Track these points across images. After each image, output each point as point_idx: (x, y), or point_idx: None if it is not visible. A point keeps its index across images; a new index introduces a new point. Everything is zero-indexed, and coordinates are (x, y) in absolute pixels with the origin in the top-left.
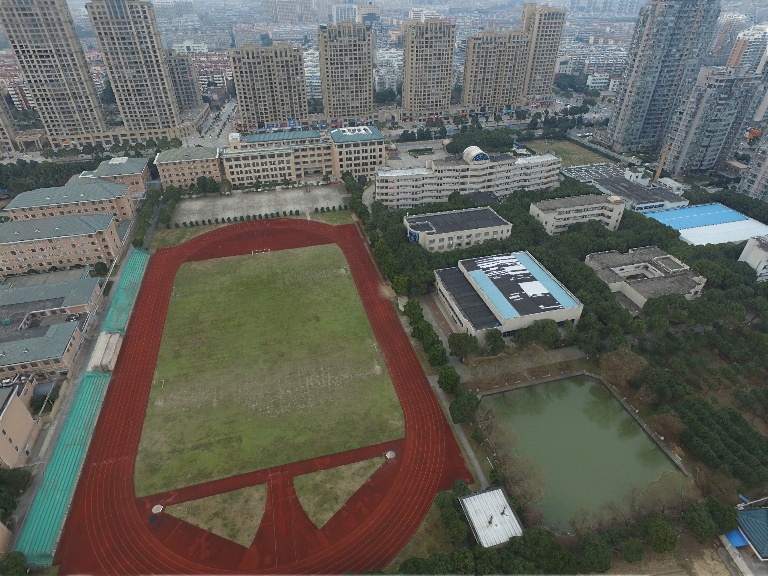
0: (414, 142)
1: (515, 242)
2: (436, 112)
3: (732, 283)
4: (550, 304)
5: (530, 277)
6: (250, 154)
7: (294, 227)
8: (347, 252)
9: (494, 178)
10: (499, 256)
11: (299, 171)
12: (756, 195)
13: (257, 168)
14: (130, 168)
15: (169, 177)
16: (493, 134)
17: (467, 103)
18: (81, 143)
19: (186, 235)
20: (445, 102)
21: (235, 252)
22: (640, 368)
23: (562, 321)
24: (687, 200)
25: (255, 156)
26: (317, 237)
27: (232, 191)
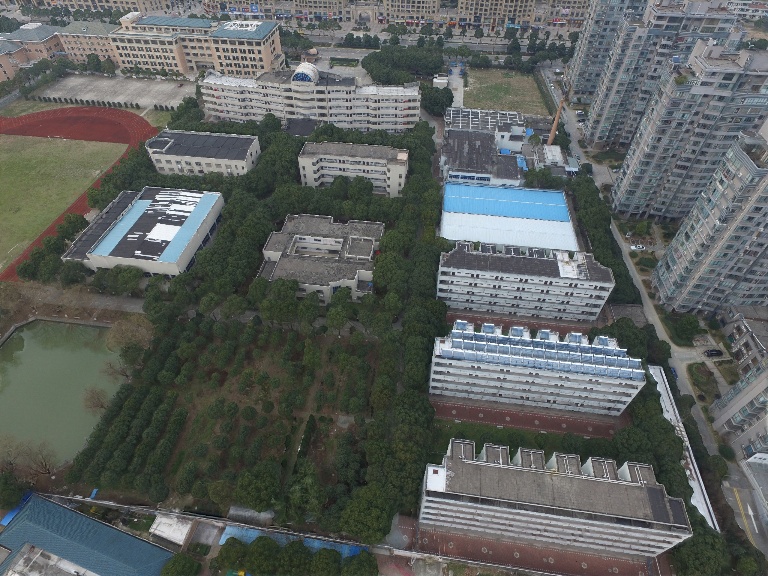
0: (356, 49)
1: (235, 181)
2: (417, 16)
3: (389, 289)
4: (150, 252)
5: (180, 221)
6: (133, 37)
7: (118, 120)
8: (125, 155)
9: (325, 105)
10: (188, 191)
11: (191, 63)
12: (623, 193)
13: (143, 53)
14: (34, 35)
15: (72, 50)
16: (421, 52)
17: (460, 9)
18: (66, 4)
19: (31, 109)
20: (430, 4)
21: (43, 133)
22: (123, 340)
23: (160, 273)
24: (519, 179)
25: (139, 40)
26: (122, 134)
27: (121, 74)
